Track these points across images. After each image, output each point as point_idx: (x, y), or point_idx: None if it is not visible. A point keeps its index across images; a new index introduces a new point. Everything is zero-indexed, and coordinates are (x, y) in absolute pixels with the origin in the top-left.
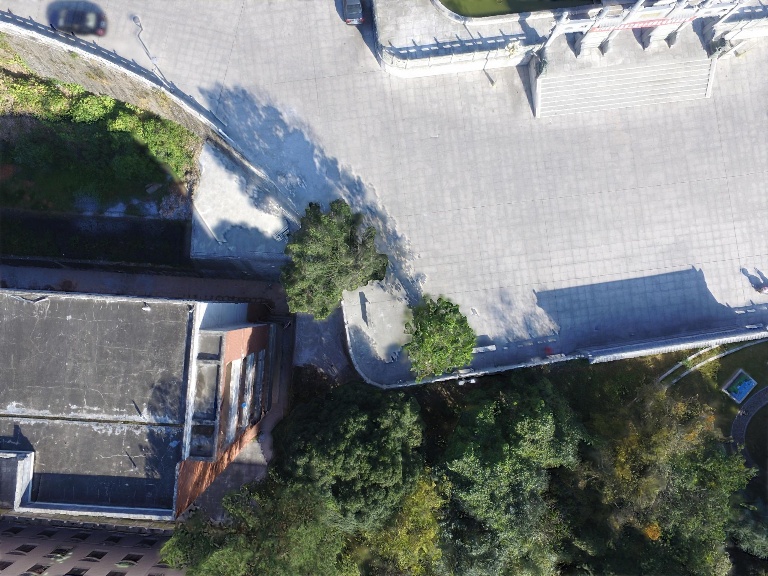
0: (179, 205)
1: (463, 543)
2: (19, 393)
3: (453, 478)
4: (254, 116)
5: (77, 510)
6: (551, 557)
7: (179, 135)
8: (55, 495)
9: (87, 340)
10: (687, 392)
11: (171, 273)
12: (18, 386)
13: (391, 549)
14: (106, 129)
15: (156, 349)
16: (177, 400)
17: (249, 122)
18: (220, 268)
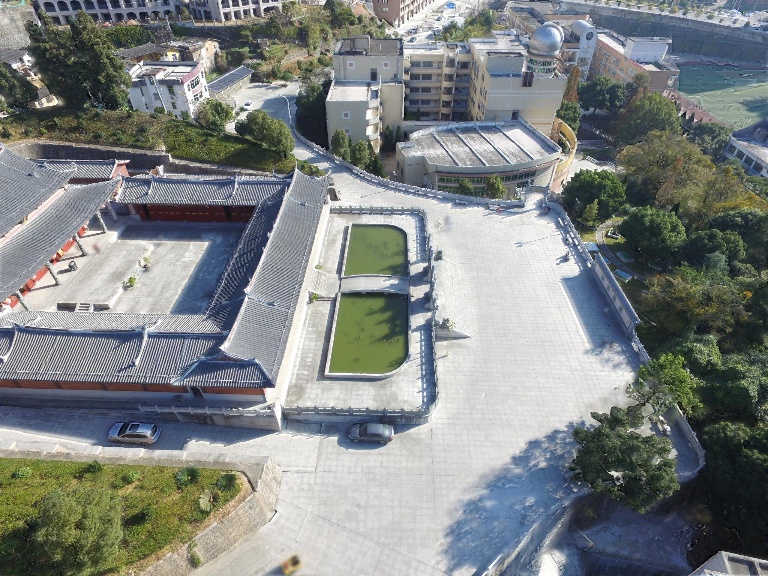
0: None
1: None
2: None
3: (763, 400)
4: (466, 538)
5: None
6: None
7: None
8: None
9: None
10: (632, 296)
11: None
12: None
13: None
14: None
15: None
16: None
17: (472, 545)
18: None
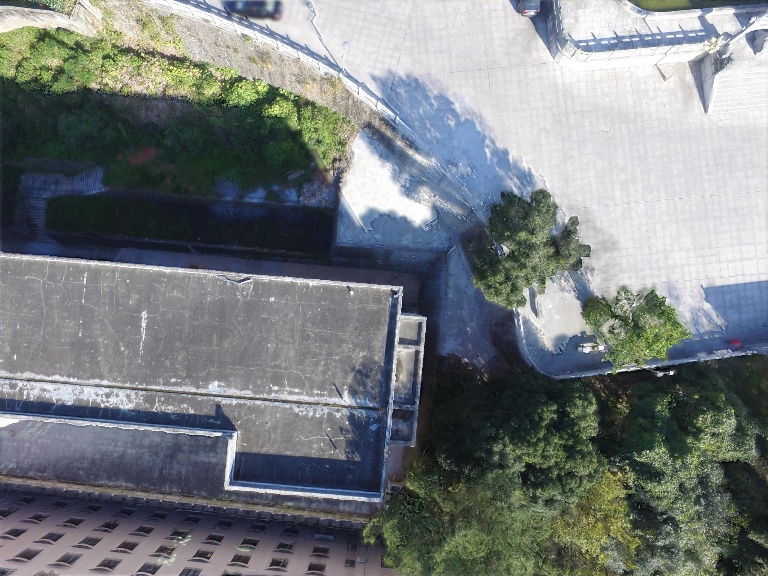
0: (322, 192)
1: (644, 533)
2: (221, 373)
3: (639, 469)
4: (426, 105)
5: (284, 490)
6: (713, 550)
7: (333, 122)
8: (256, 475)
9: (290, 322)
10: None
11: (299, 260)
12: (220, 366)
13: (566, 538)
14: (256, 114)
15: (358, 333)
16: (378, 384)
17: (421, 110)
18: (356, 256)
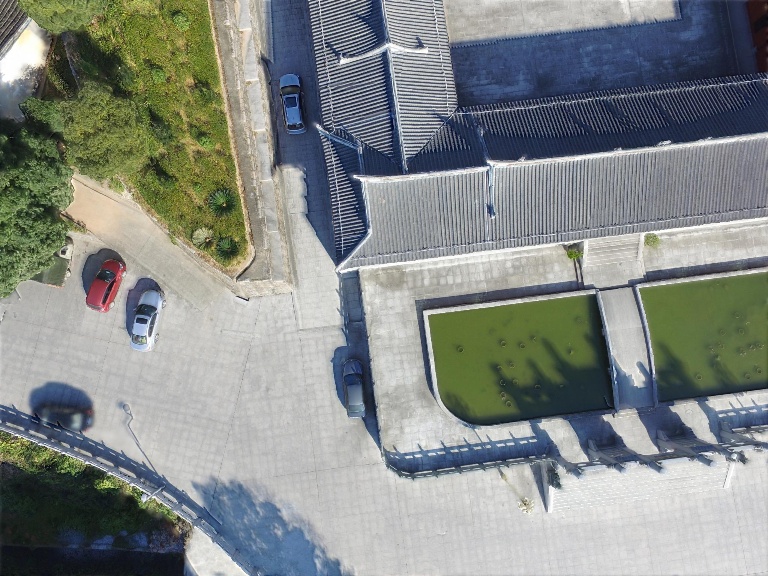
0: (170, 545)
1: None
2: None
3: None
4: (251, 513)
5: None
6: None
7: None
8: None
9: None
10: None
11: None
12: None
13: None
14: (93, 476)
15: None
16: None
17: (245, 519)
18: None
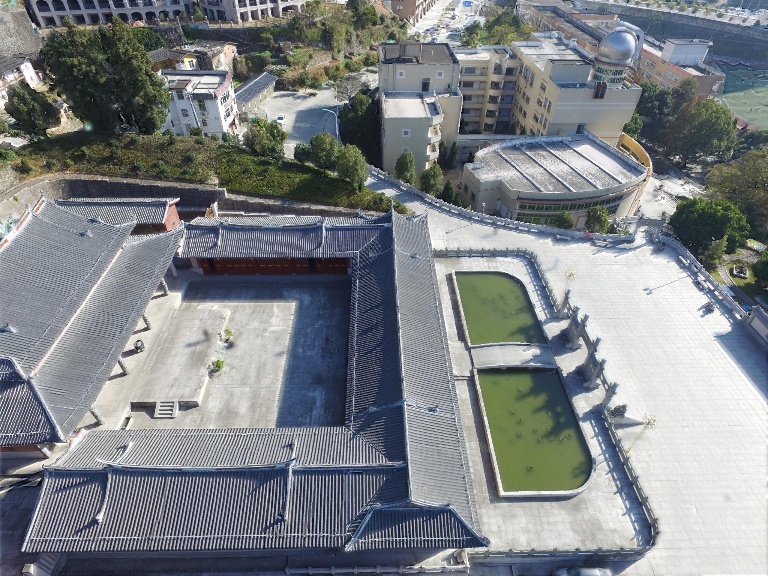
0: None
1: None
2: None
3: None
4: None
5: None
6: None
7: None
8: None
9: None
10: None
11: None
12: None
13: None
14: None
15: None
16: None
17: None
18: None
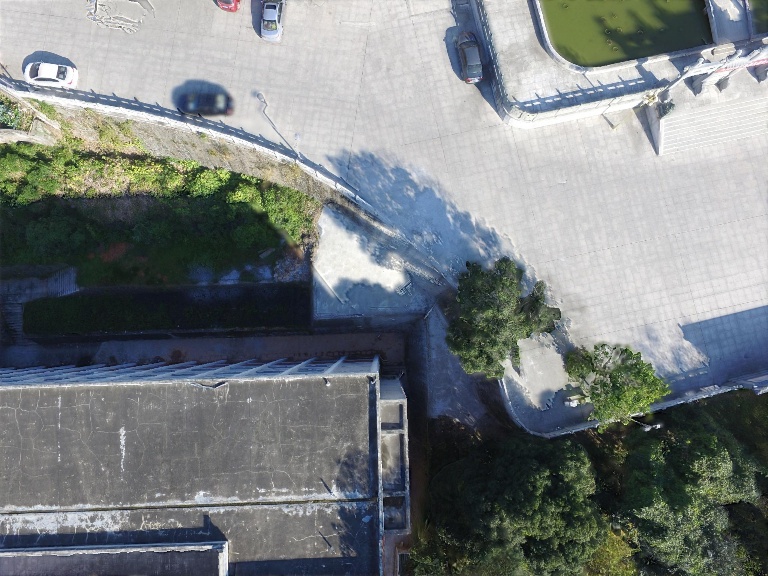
0: (295, 268)
1: None
2: (206, 482)
3: (642, 525)
4: (384, 179)
5: None
6: None
7: (297, 201)
8: None
9: (269, 421)
10: None
11: (281, 333)
12: (204, 475)
13: None
14: (221, 201)
15: (339, 424)
16: (365, 474)
17: (380, 185)
18: (336, 325)
